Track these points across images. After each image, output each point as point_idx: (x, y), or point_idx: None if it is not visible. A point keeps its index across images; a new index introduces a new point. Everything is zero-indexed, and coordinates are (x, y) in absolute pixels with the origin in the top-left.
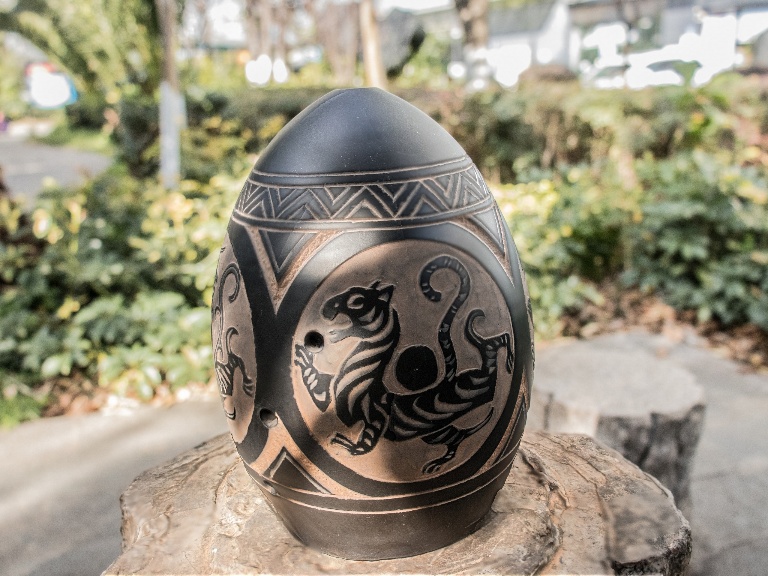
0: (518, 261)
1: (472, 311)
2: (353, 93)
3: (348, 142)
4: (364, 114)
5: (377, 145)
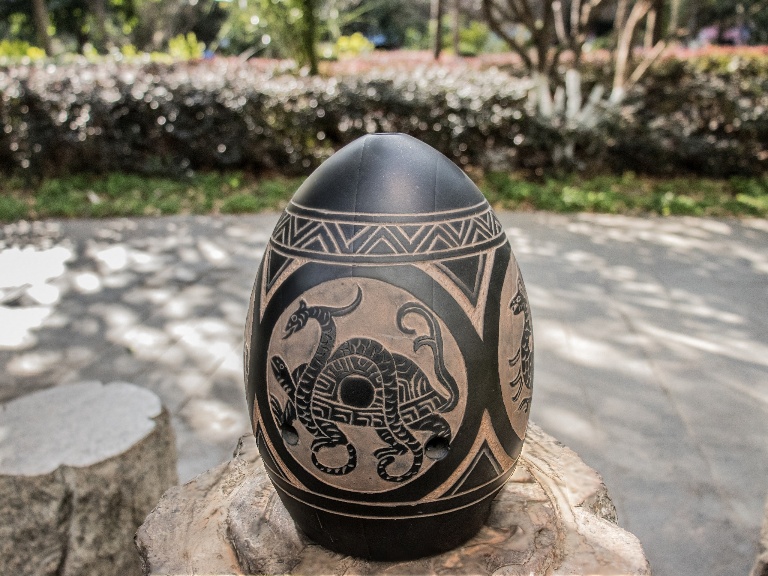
0: (284, 318)
1: None
2: None
3: None
4: None
5: None
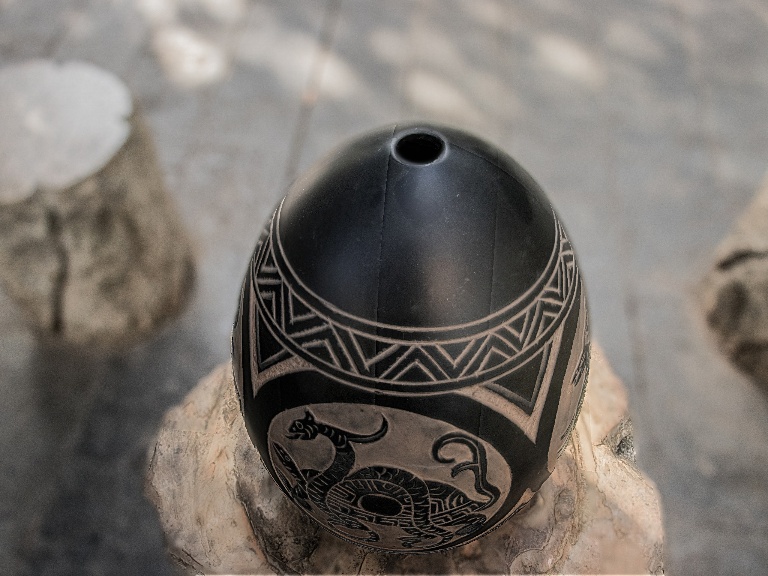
0: (286, 417)
1: (233, 338)
2: (381, 139)
3: (321, 157)
4: (340, 156)
5: (303, 180)
